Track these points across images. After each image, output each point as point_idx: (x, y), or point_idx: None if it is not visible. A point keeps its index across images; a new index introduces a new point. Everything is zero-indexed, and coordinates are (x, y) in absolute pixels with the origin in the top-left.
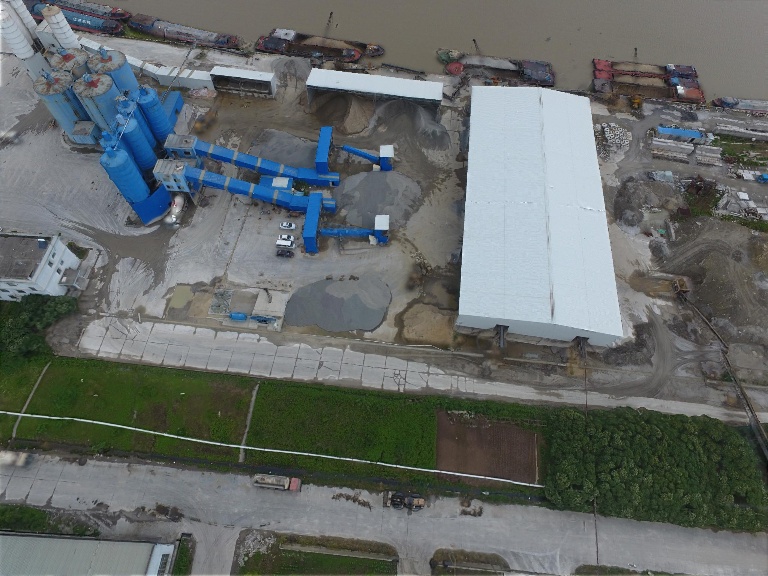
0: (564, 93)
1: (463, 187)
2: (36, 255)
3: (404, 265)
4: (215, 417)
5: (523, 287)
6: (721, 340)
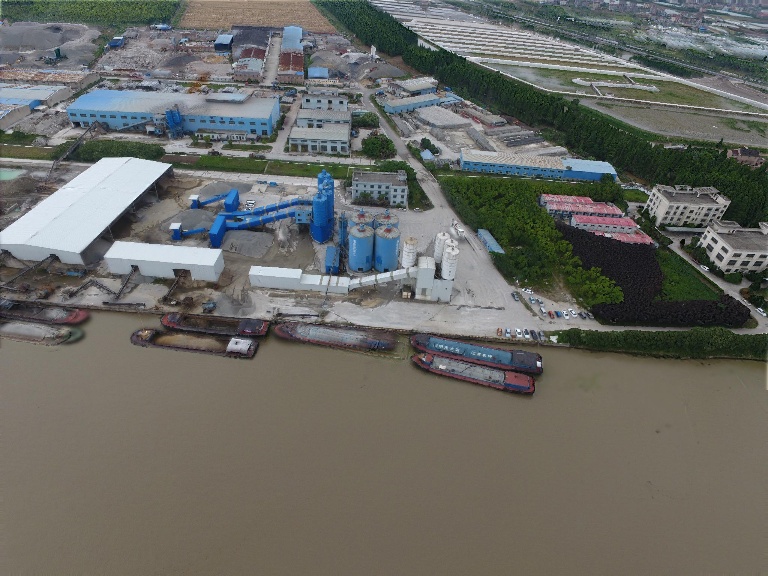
0: (5, 244)
1: (131, 228)
2: (358, 178)
3: (188, 199)
4: None
5: (136, 166)
6: (54, 163)
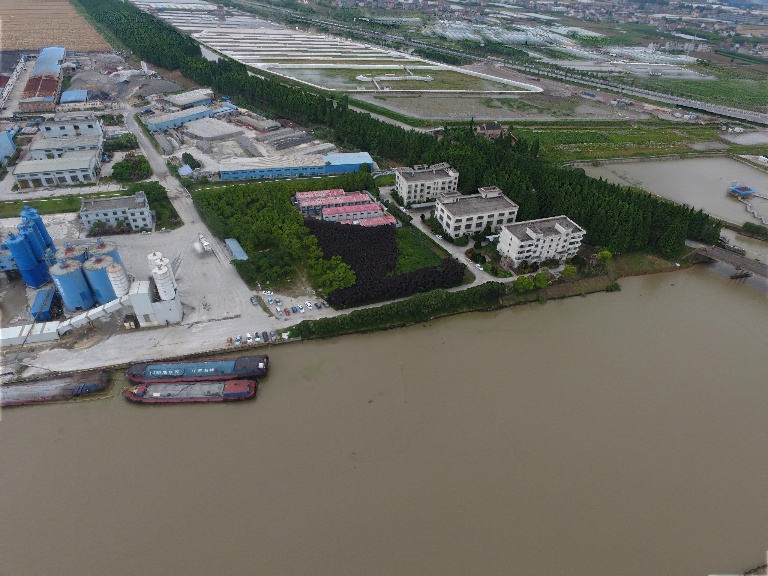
0: None
1: None
2: (88, 208)
3: None
4: (0, 206)
5: None
6: None
